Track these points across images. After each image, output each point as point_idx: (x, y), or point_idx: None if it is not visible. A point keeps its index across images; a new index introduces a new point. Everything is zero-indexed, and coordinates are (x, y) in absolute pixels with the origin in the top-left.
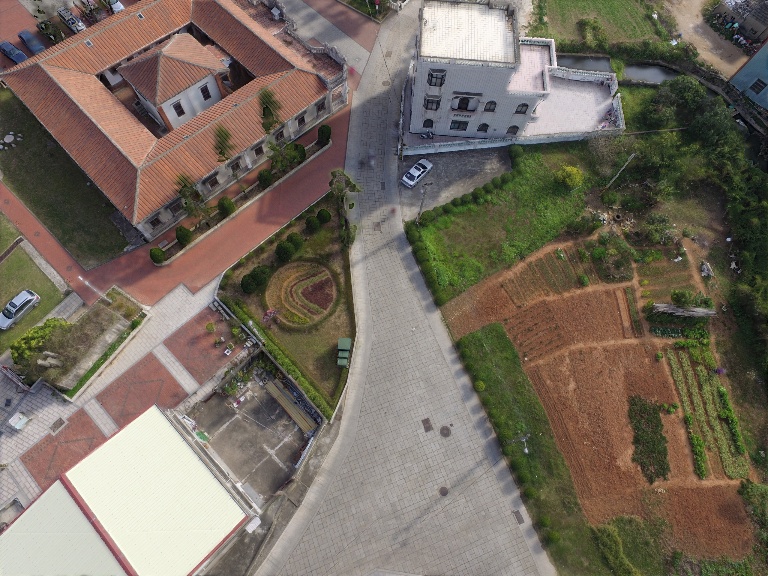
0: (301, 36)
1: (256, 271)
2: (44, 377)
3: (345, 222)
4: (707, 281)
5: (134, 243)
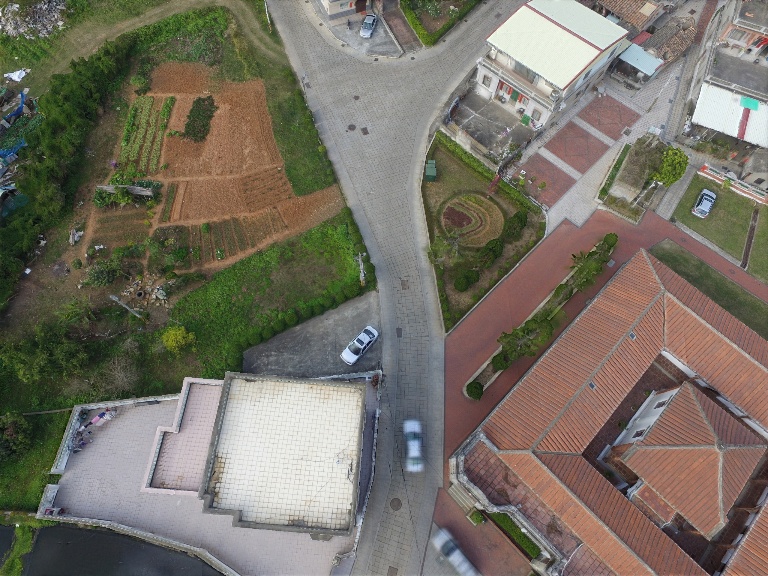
0: None
1: (517, 220)
2: None
3: None
4: (82, 227)
5: None
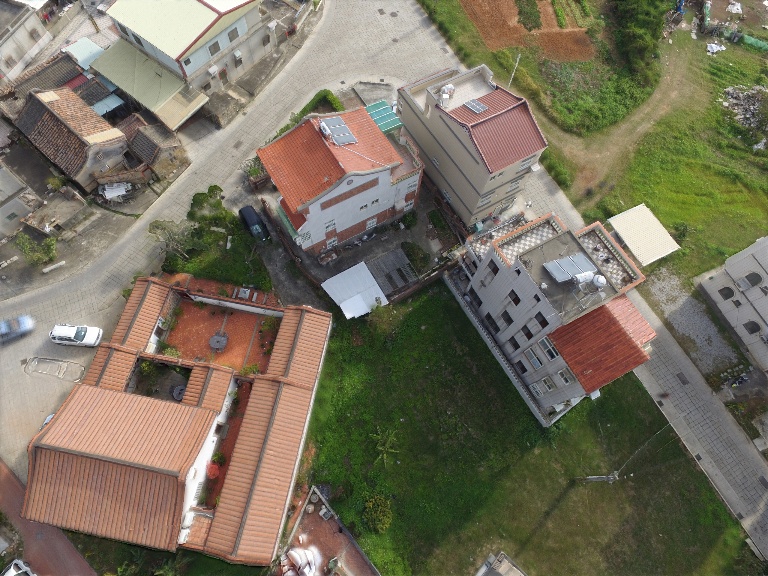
0: None
1: None
2: None
3: None
4: None
5: None
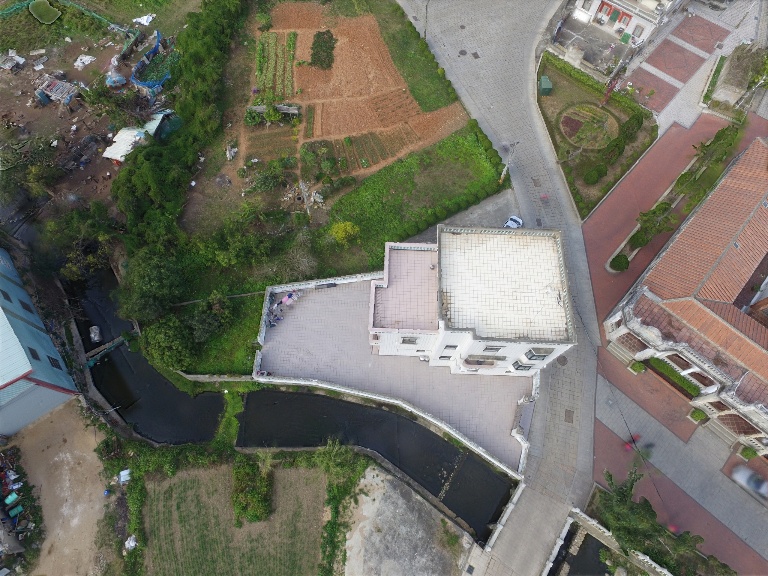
0: (705, 445)
1: (635, 121)
2: None
3: None
4: (235, 144)
5: None
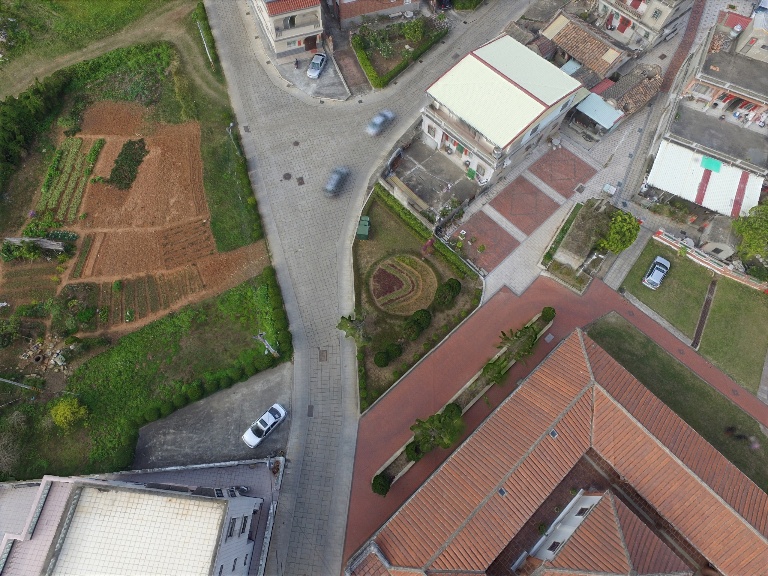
0: None
1: (447, 289)
2: None
3: None
4: None
5: None
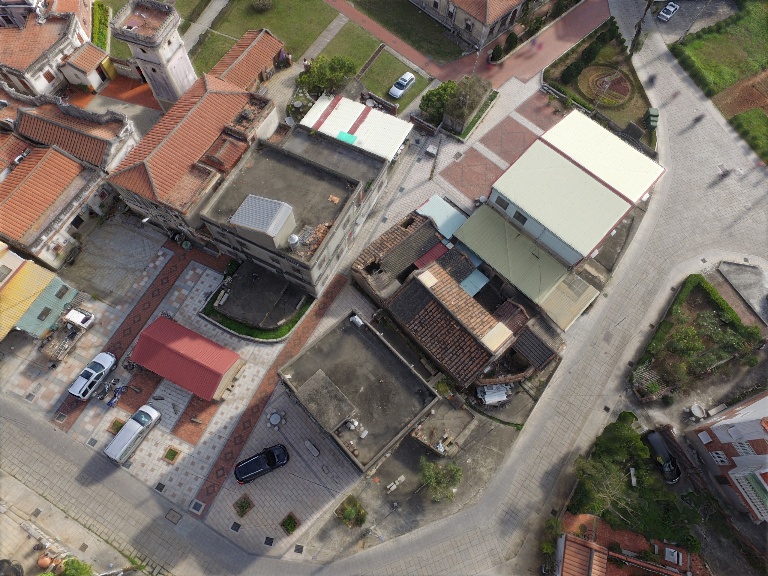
0: None
1: (578, 62)
2: (458, 114)
3: (638, 32)
4: None
5: (468, 51)
